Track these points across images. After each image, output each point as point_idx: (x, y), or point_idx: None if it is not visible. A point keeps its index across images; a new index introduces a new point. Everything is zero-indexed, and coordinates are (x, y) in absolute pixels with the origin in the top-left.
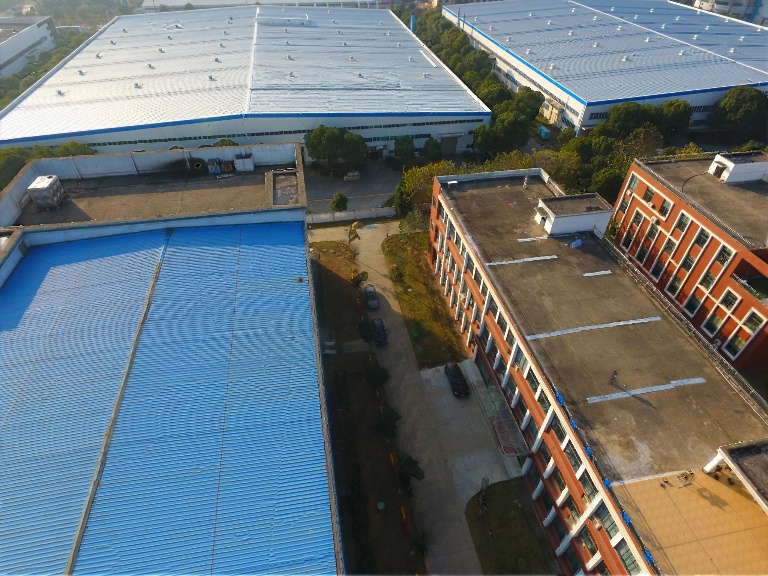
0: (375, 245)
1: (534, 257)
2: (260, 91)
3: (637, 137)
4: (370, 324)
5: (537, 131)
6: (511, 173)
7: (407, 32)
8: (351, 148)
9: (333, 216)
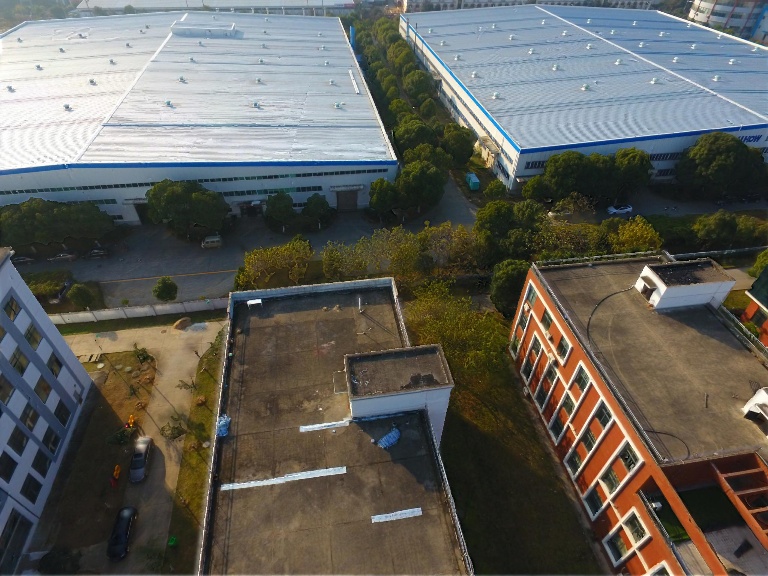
0: (191, 359)
1: (308, 471)
2: (114, 128)
3: (565, 208)
4: (53, 563)
5: (466, 178)
6: (348, 285)
7: (346, 46)
8: (201, 211)
9: (154, 309)
